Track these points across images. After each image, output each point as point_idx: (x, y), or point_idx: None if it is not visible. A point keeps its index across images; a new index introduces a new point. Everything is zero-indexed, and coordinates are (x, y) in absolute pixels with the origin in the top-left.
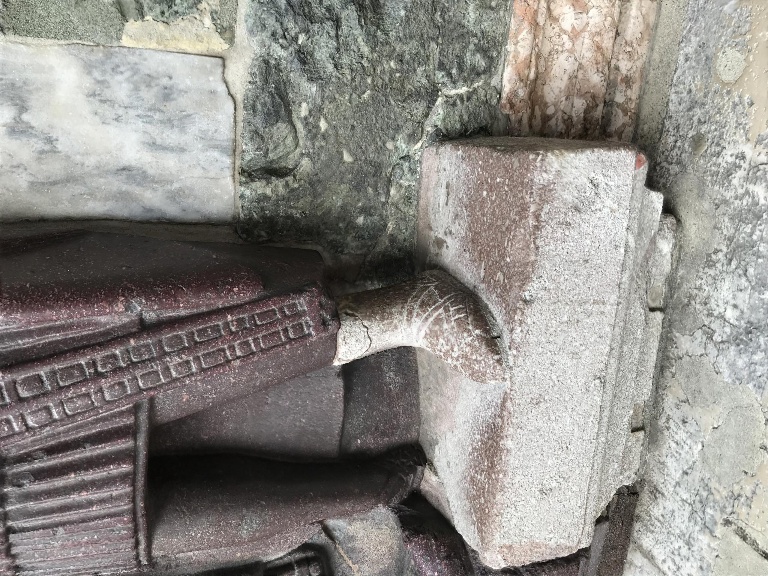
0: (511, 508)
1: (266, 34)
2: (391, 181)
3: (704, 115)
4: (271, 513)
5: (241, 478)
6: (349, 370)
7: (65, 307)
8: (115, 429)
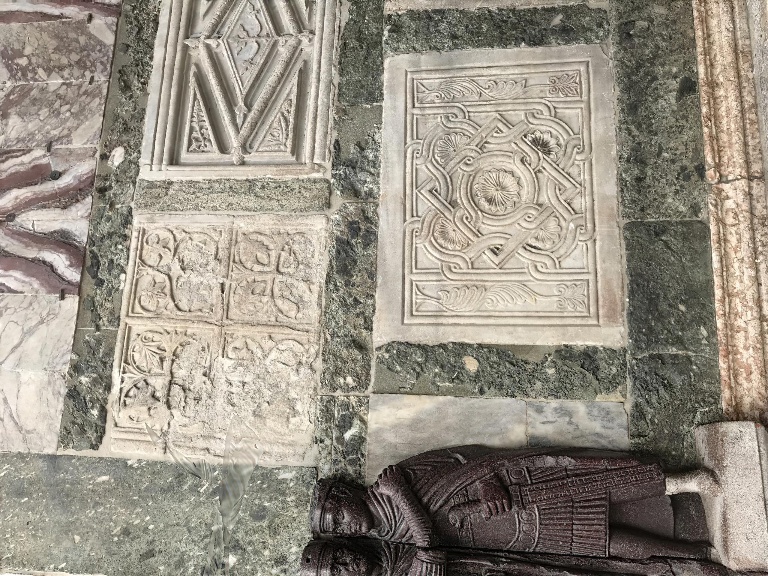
0: (735, 543)
1: (636, 396)
2: (684, 440)
3: None
4: (649, 546)
5: (637, 533)
6: (675, 508)
7: (589, 461)
8: (601, 498)
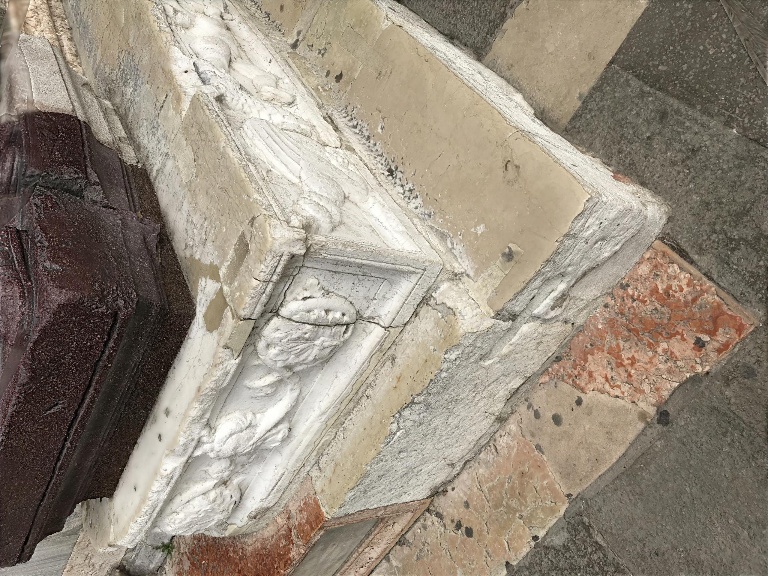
0: None
1: None
2: None
3: (108, 85)
4: None
5: None
6: None
7: None
8: None
